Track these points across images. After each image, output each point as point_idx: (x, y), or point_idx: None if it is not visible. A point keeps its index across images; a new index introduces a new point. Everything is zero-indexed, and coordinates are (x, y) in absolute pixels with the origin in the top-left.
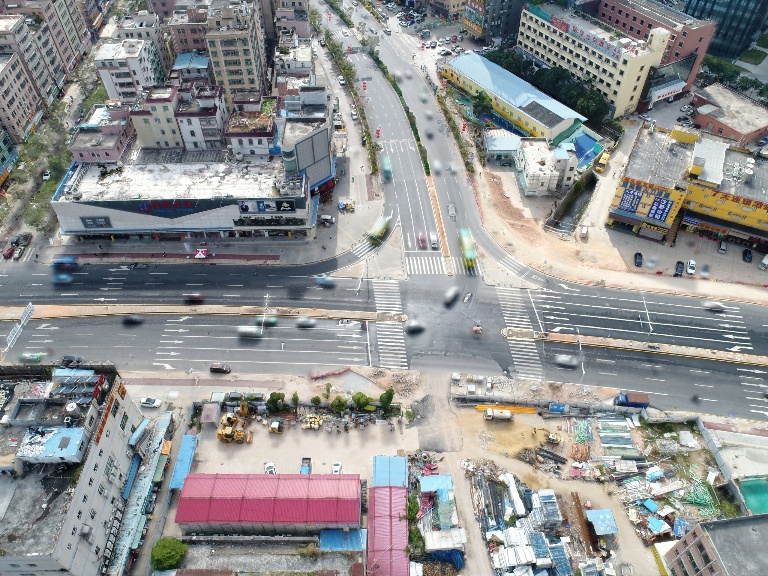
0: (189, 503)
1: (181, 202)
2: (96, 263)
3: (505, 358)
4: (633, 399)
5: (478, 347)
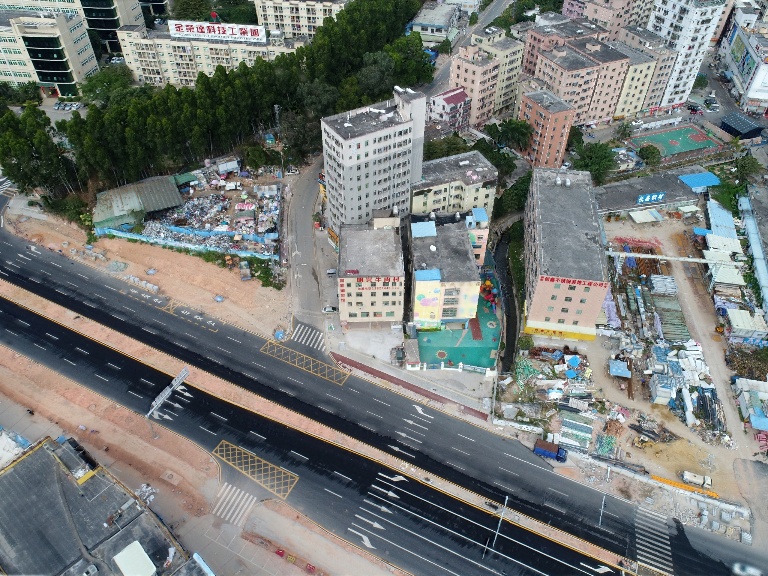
0: None
1: None
2: None
3: (681, 547)
4: (554, 446)
5: (716, 574)
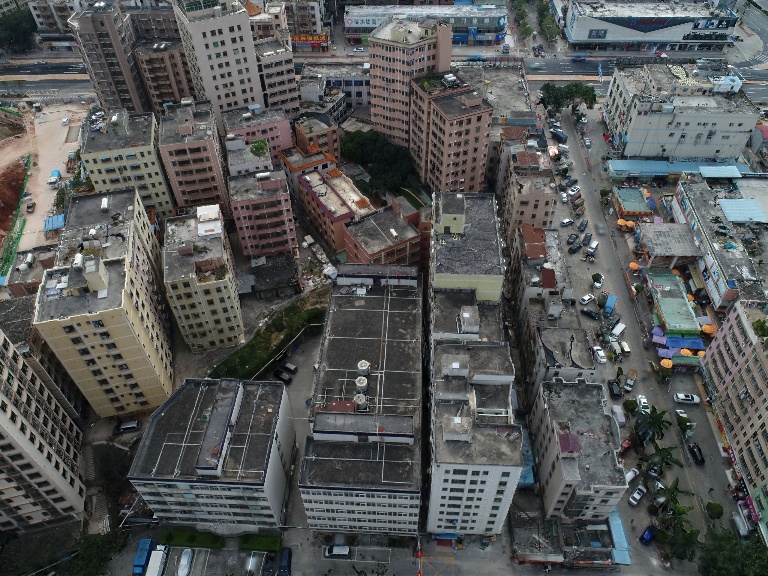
0: (767, 132)
1: (659, 19)
2: (595, 60)
3: None
4: None
5: None
